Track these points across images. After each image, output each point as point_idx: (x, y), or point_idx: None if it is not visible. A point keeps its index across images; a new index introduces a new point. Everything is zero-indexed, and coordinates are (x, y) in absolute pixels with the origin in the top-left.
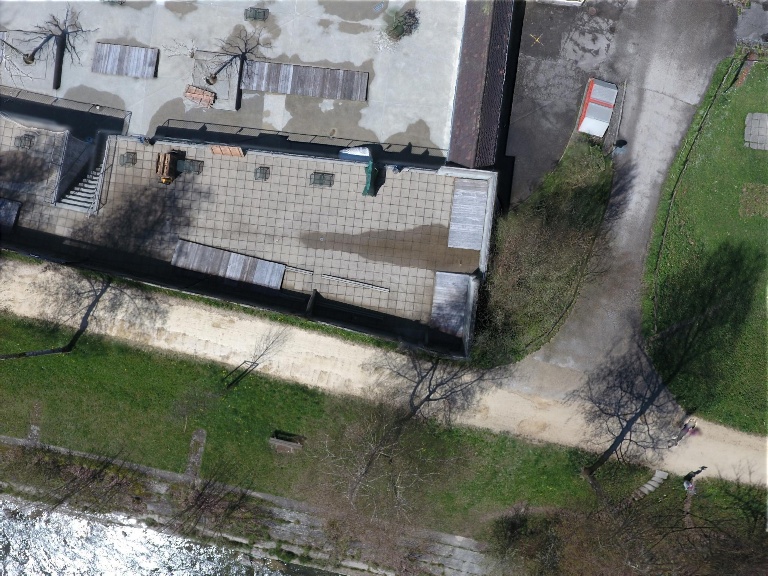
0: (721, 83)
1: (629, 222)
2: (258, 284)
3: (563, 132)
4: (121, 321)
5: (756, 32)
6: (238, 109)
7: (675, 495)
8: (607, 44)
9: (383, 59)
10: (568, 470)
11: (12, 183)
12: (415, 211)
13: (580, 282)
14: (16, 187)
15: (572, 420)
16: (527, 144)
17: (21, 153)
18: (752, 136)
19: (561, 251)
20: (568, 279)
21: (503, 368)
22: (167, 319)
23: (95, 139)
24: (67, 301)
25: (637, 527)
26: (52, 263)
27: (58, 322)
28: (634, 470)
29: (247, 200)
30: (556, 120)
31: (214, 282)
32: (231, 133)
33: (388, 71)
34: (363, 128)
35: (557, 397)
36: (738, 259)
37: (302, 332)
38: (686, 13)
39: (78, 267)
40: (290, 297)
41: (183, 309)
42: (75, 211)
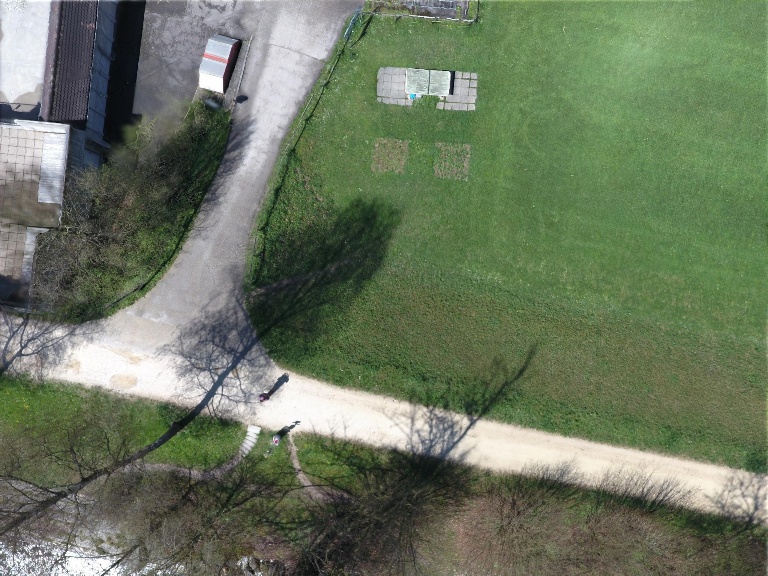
0: (349, 37)
1: (242, 177)
2: None
3: (189, 89)
4: None
5: None
6: None
7: (277, 451)
8: None
9: (11, 19)
10: (161, 425)
11: None
12: (6, 166)
13: (183, 237)
14: None
15: (163, 375)
16: (154, 102)
17: None
18: (384, 91)
19: (169, 207)
20: (170, 234)
21: (94, 323)
22: None
23: None
24: None
25: (255, 485)
26: None
27: None
28: (226, 425)
29: None
30: (182, 77)
31: None
32: None
33: (17, 31)
34: None
35: (148, 351)
36: (371, 215)
37: None
38: None
39: None
40: None
41: None
42: None
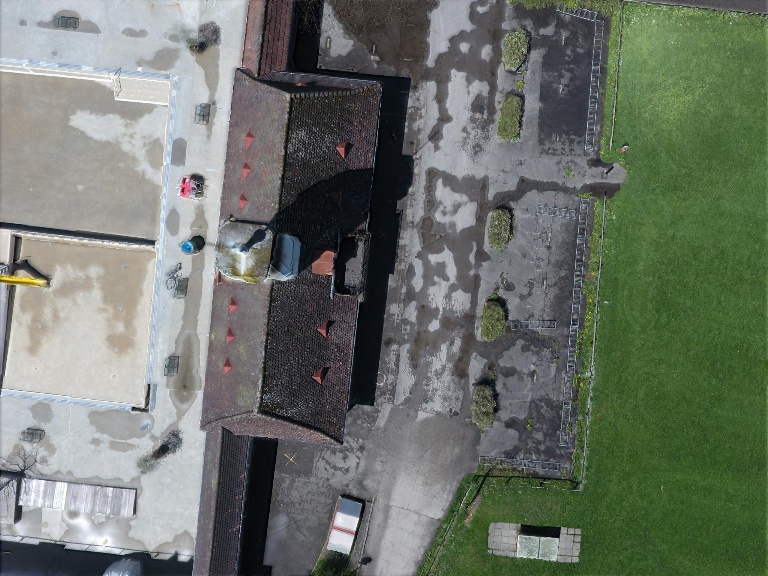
0: None
1: None
2: None
3: (316, 544)
4: None
5: (498, 449)
6: (19, 521)
7: None
8: (357, 462)
9: (150, 475)
10: None
11: None
12: None
13: None
14: None
15: None
16: (283, 554)
17: None
18: (495, 544)
19: None
20: None
21: None
22: None
23: None
24: None
25: None
26: None
27: None
28: None
29: None
30: (309, 533)
31: None
32: (14, 541)
33: (155, 486)
34: (133, 538)
35: None
36: None
37: None
38: (431, 432)
39: None
40: None
41: None
42: None
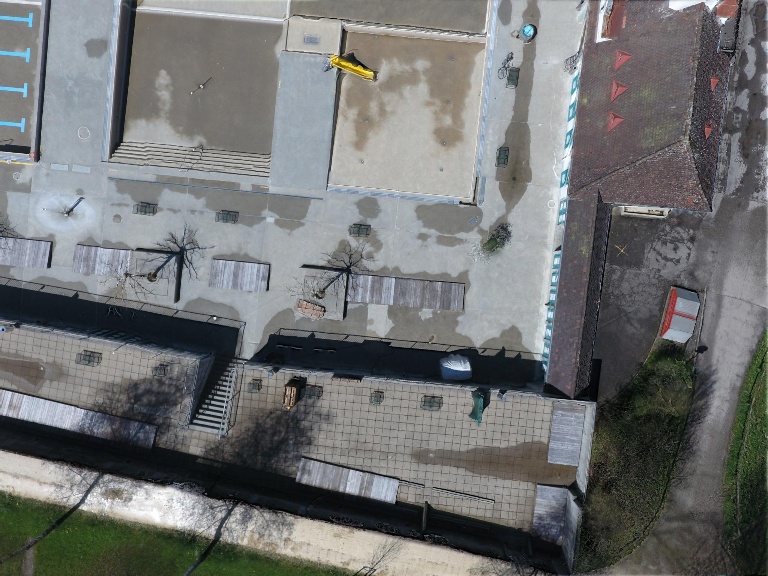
0: None
1: (711, 426)
2: (375, 499)
3: (647, 336)
4: (251, 532)
5: None
6: (344, 318)
7: None
8: (688, 253)
9: (478, 270)
10: None
11: (149, 407)
12: (517, 429)
13: (667, 486)
14: (153, 411)
15: None
16: (613, 348)
17: (156, 380)
18: None
19: (649, 456)
20: (656, 484)
21: (599, 571)
22: (293, 530)
23: (214, 350)
24: (202, 515)
25: None
26: (188, 482)
27: (195, 534)
28: None
29: (363, 421)
30: (640, 325)
31: (335, 497)
32: (338, 340)
33: (483, 281)
34: (460, 334)
35: None
36: None
37: (415, 541)
38: (762, 222)
39: (219, 497)
40: (404, 510)
41: (307, 521)
42: (207, 432)
